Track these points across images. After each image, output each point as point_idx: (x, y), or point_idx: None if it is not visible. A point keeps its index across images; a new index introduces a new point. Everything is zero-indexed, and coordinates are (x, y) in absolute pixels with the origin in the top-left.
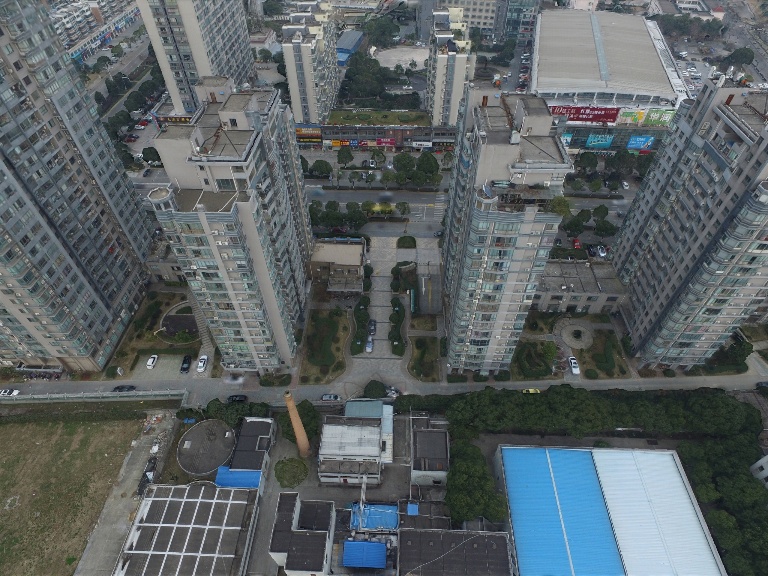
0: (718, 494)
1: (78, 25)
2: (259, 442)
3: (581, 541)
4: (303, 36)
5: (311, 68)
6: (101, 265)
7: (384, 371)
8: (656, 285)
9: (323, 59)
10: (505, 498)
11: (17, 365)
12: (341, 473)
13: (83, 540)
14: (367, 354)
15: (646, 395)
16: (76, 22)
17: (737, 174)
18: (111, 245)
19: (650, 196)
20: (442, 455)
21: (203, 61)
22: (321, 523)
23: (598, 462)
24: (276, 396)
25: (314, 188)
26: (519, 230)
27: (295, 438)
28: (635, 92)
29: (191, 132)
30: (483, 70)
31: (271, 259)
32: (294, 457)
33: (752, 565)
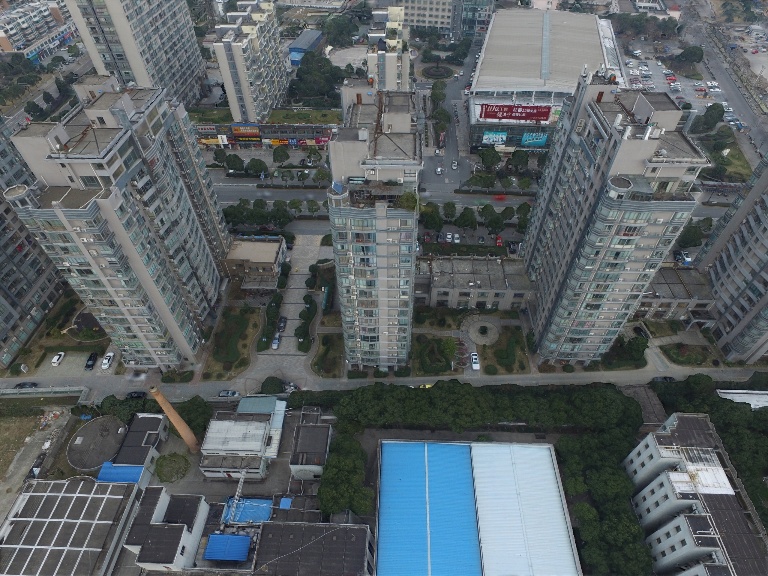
0: (585, 487)
1: (35, 25)
2: (147, 438)
3: (443, 533)
4: (236, 35)
5: (244, 67)
6: (6, 263)
7: (287, 367)
8: (549, 281)
9: (259, 58)
10: (372, 491)
11: None
12: (222, 468)
13: None
14: (273, 351)
15: (536, 390)
16: (33, 22)
17: (597, 170)
18: (19, 243)
19: (546, 193)
20: (321, 450)
21: (137, 60)
22: (187, 517)
23: (475, 456)
24: (176, 392)
25: (249, 187)
26: (375, 226)
27: None
28: (572, 90)
29: (51, 130)
30: (435, 69)
31: (149, 256)
32: (184, 452)
33: (607, 556)
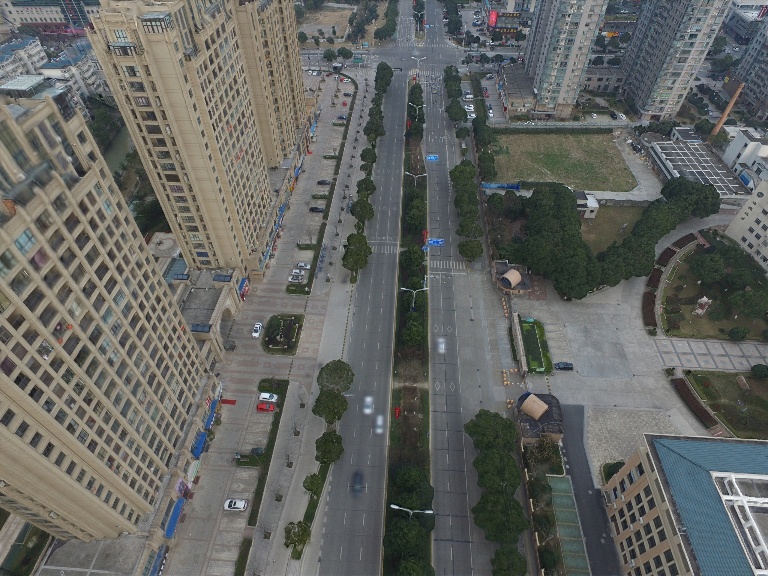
0: None
1: None
2: None
3: None
4: None
5: None
6: None
7: None
8: None
9: None
10: None
11: (531, 110)
12: None
13: (625, 164)
14: (710, 116)
15: None
16: None
17: None
18: None
19: None
20: None
21: None
22: None
23: None
24: None
25: (609, 57)
26: None
27: (711, 131)
28: None
29: None
30: None
31: None
32: None
33: None
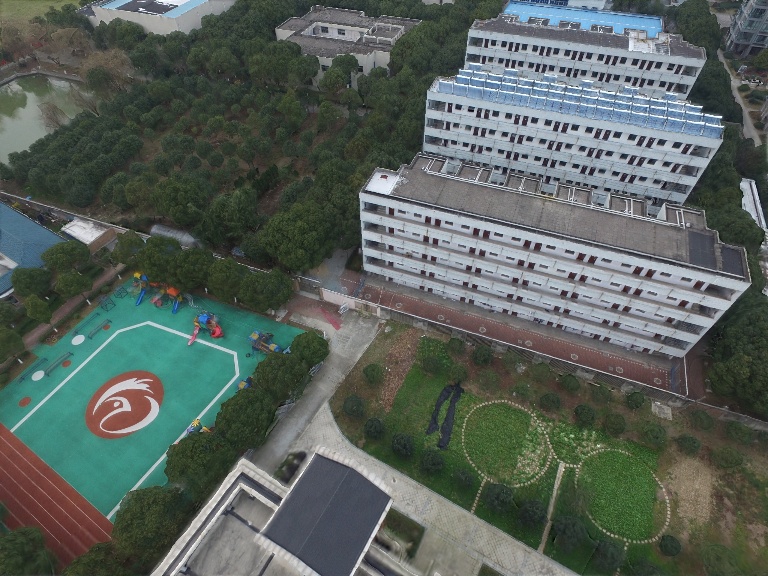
0: None
1: None
2: None
3: None
4: None
5: None
6: None
7: (721, 22)
8: None
9: None
10: (626, 2)
11: None
12: None
13: None
14: None
15: None
16: None
17: None
18: None
19: None
20: None
21: None
22: None
23: None
24: None
25: None
26: None
27: None
28: None
29: None
30: None
31: None
32: None
33: None
